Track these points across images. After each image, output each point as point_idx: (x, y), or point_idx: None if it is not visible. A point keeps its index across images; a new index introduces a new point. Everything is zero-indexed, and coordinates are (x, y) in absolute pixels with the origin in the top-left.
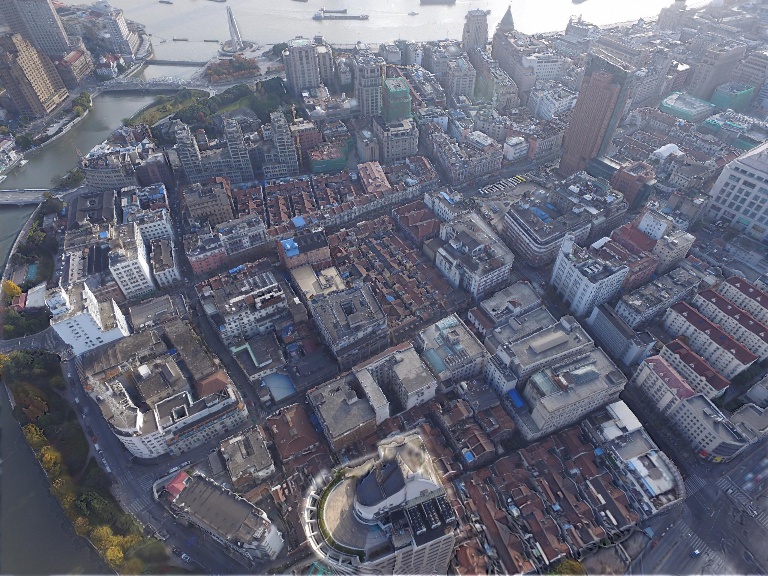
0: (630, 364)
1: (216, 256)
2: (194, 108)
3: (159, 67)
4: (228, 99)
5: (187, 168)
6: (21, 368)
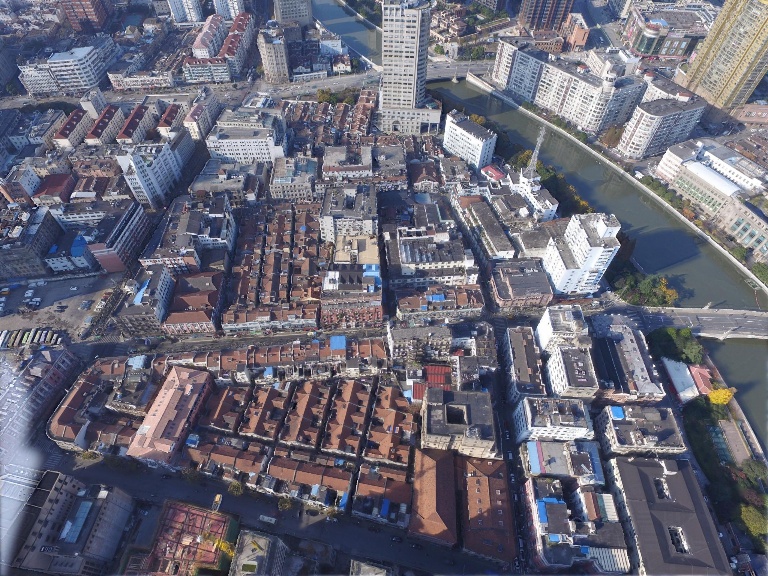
0: (194, 142)
1: None
2: None
3: None
4: None
5: None
6: None
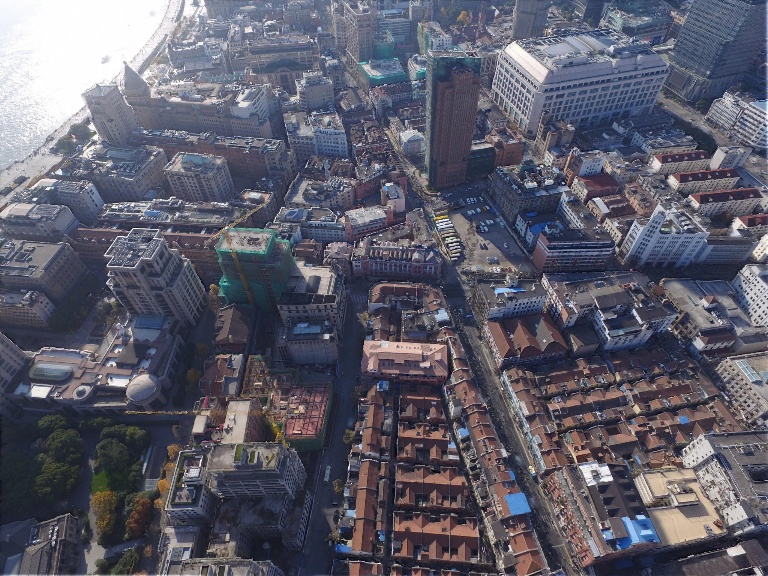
0: (748, 258)
1: None
2: None
3: None
4: None
5: None
6: None
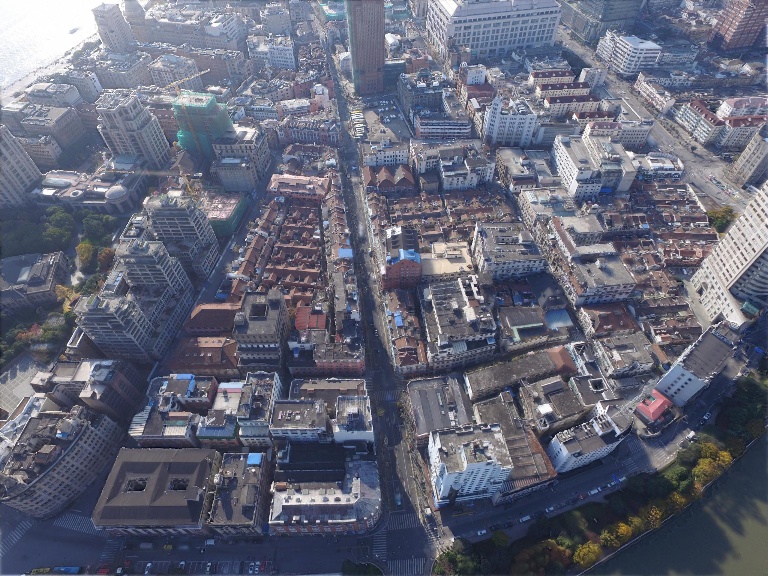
0: None
1: None
2: None
3: None
4: None
5: (140, 342)
6: None
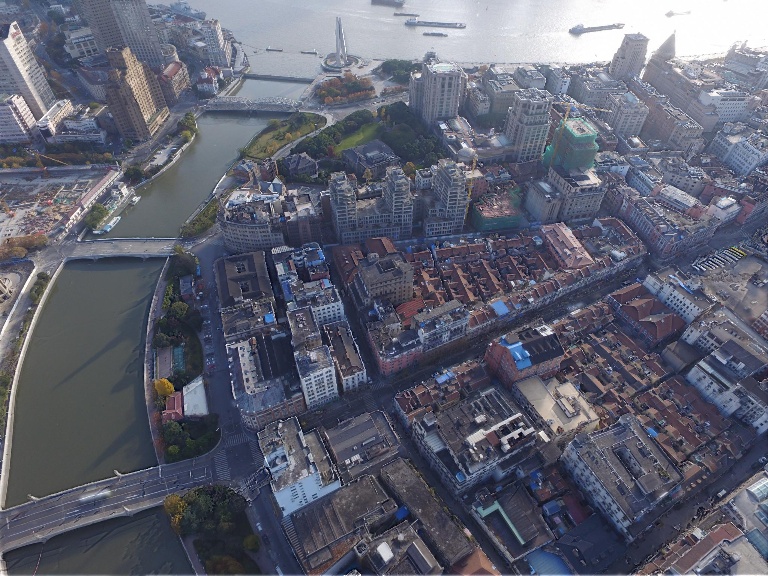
0: None
1: (411, 354)
2: (320, 139)
3: (258, 82)
4: (351, 127)
5: (341, 223)
6: (202, 518)
